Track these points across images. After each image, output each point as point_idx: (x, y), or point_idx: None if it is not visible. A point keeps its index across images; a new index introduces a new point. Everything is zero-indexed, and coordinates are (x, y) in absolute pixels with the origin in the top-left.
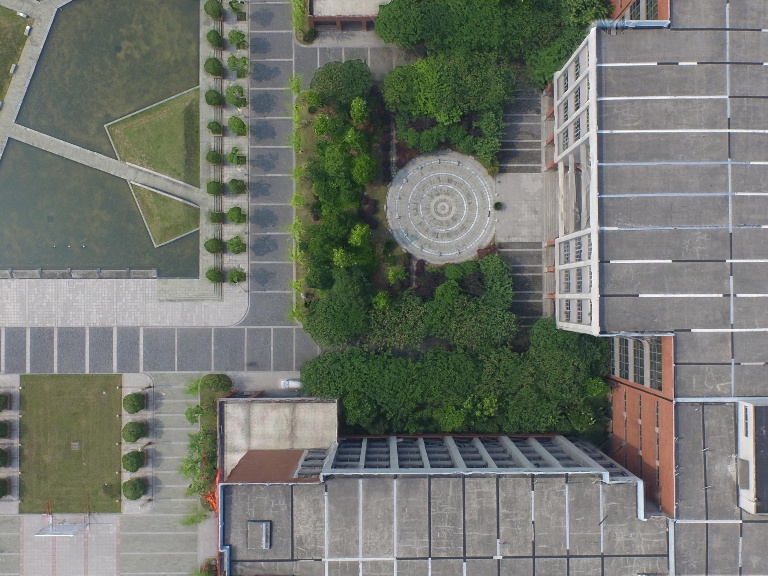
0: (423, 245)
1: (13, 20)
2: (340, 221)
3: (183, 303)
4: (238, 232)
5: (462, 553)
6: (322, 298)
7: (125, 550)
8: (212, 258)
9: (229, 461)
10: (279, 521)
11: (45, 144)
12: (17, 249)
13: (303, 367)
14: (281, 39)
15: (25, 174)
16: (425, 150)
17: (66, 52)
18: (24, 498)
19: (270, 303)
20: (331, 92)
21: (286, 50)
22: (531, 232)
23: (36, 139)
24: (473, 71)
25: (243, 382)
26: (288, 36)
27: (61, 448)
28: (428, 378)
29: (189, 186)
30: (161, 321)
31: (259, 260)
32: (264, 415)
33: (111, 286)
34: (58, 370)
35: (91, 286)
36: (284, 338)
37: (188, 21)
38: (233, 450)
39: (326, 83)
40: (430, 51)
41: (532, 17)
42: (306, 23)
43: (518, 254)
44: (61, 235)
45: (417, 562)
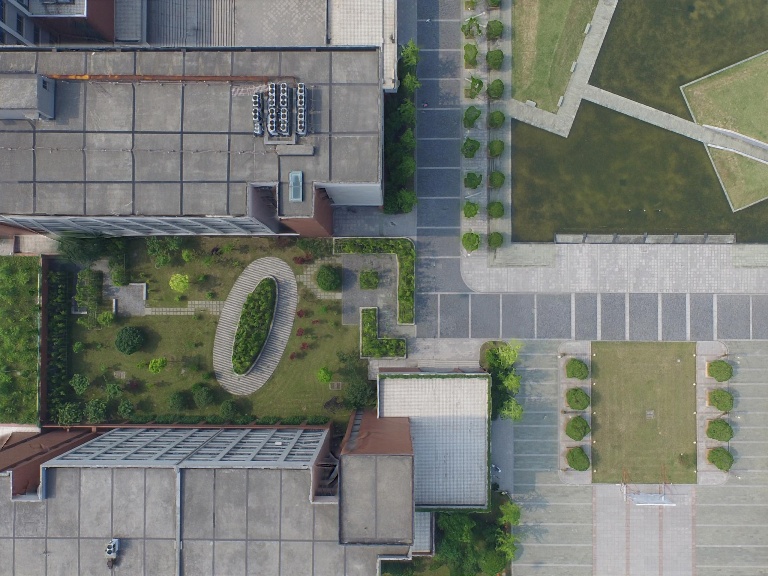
0: None
1: None
2: None
3: (759, 269)
4: None
5: None
6: None
7: (700, 522)
8: None
9: None
10: None
11: (619, 106)
12: (589, 213)
13: None
14: None
15: (597, 136)
16: None
17: (638, 12)
18: (597, 467)
19: None
20: None
21: None
22: None
23: (610, 101)
24: None
25: None
26: None
27: (636, 417)
28: None
29: None
30: (736, 288)
31: None
32: None
33: (685, 251)
34: (630, 337)
35: (664, 251)
36: None
37: None
38: None
39: None
40: None
41: None
42: None
43: None
44: (634, 199)
45: None
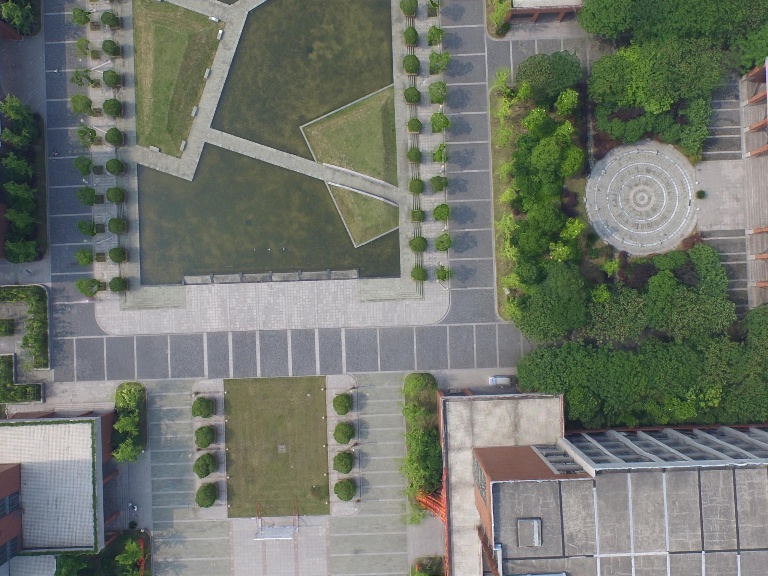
0: (624, 236)
1: (206, 25)
2: (556, 215)
3: (384, 303)
4: (437, 229)
5: (736, 545)
6: (528, 293)
7: (335, 552)
8: (413, 256)
9: (453, 460)
10: (548, 518)
11: (241, 148)
12: (217, 254)
13: (520, 363)
14: (473, 34)
15: (222, 179)
16: (628, 140)
17: (258, 55)
18: (233, 502)
19: (471, 300)
20: (540, 85)
21: (478, 44)
22: (733, 220)
23: (232, 143)
24: (685, 58)
25: (447, 380)
26: (479, 30)
27: (268, 451)
28: (651, 370)
29: (388, 185)
30: (362, 321)
31: (458, 257)
32: (487, 412)
33: (311, 288)
34: (261, 374)
35: (291, 288)
36: (487, 335)
37: (379, 19)
38: (457, 448)
39: (535, 76)
40: (634, 40)
41: (741, 1)
42: (502, 16)
43: (721, 242)
44: (260, 238)
45: (690, 556)
